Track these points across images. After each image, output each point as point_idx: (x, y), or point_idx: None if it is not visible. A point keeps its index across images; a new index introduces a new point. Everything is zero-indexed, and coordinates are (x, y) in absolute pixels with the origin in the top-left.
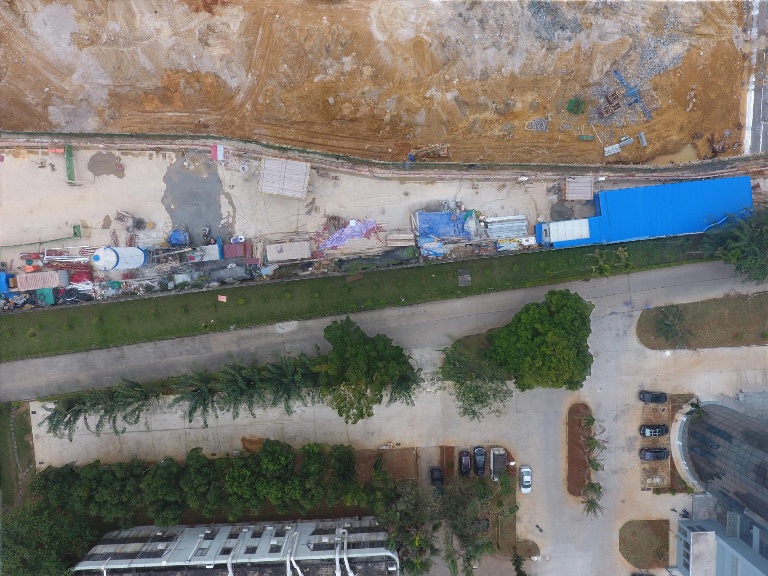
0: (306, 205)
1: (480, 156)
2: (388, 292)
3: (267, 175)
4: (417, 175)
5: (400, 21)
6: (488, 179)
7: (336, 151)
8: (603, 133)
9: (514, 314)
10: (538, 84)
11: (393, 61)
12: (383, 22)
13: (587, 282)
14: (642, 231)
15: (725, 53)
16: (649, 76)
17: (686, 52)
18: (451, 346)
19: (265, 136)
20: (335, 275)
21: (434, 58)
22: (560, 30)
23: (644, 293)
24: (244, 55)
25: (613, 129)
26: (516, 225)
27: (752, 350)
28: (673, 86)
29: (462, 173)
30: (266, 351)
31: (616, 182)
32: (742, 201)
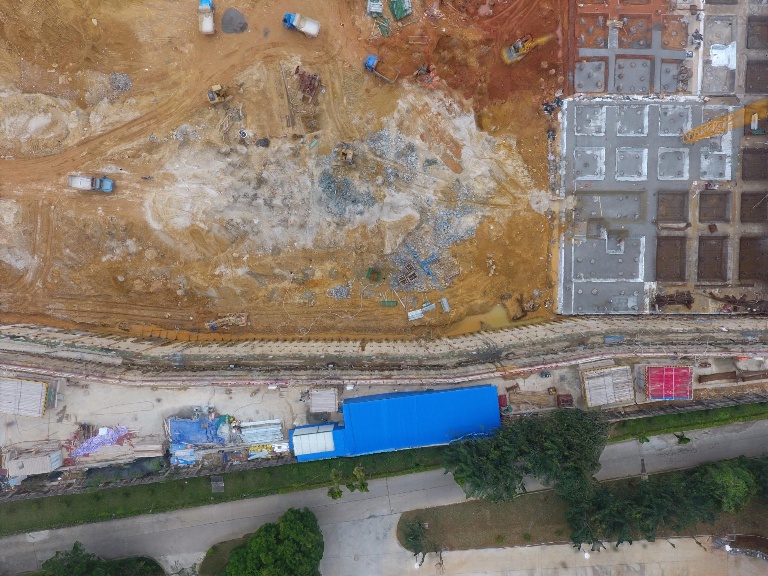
0: (57, 413)
1: (282, 322)
2: (140, 500)
3: (2, 395)
4: (166, 384)
5: (175, 210)
6: (241, 384)
7: (137, 320)
8: (406, 298)
9: (270, 519)
10: (335, 254)
11: (175, 244)
12: (158, 212)
13: (345, 485)
14: (387, 443)
15: (520, 223)
16: (447, 245)
17: (479, 224)
18: (206, 552)
19: (60, 310)
20: (74, 493)
21: (219, 239)
22: (351, 205)
23: (403, 496)
24: (25, 242)
25: (416, 294)
26: (270, 430)
27: (517, 551)
28: (472, 254)
29: (215, 379)
30: (17, 560)
31: (372, 385)
32: (489, 412)
